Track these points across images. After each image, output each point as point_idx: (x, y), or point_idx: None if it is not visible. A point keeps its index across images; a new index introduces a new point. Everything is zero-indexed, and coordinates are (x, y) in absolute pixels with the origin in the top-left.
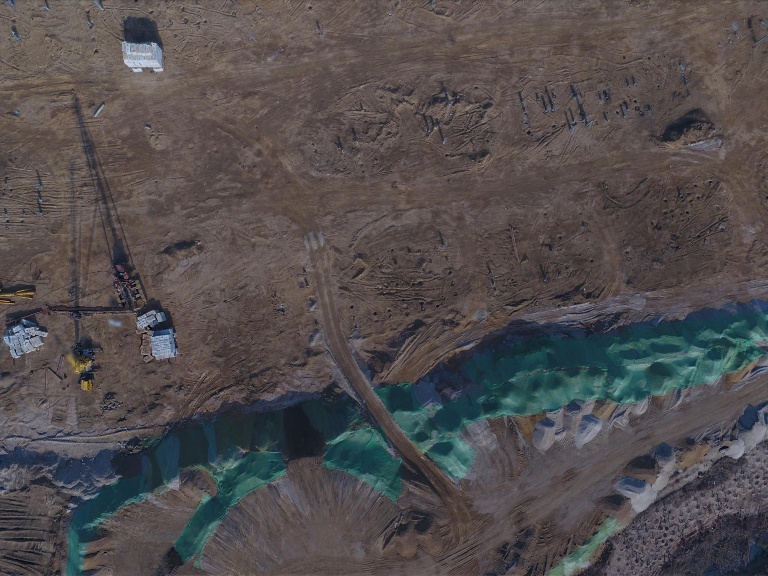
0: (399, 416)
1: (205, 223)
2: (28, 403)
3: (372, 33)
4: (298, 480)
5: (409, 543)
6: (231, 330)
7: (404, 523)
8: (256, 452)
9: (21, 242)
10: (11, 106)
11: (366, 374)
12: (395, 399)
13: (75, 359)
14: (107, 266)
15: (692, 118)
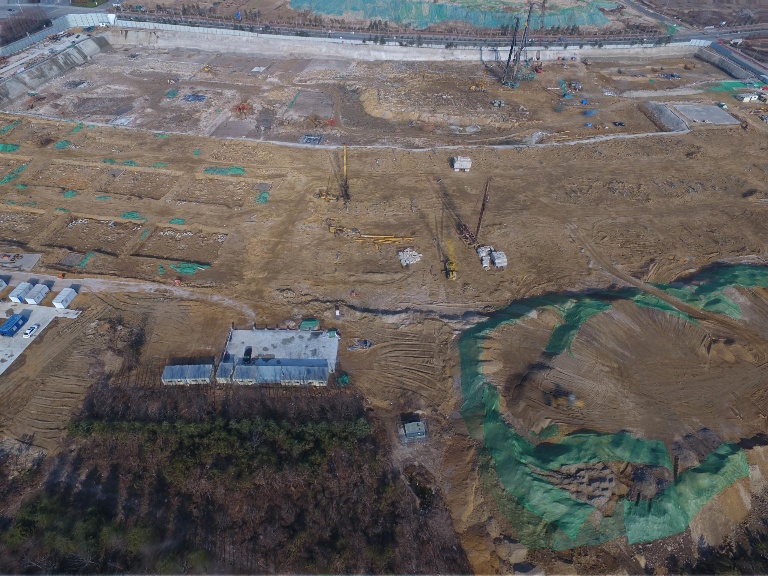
0: (671, 291)
1: (505, 218)
2: (413, 286)
3: (568, 164)
4: (623, 311)
5: (727, 349)
6: (536, 258)
7: (714, 339)
8: (584, 301)
9: (402, 221)
10: (394, 179)
11: (634, 277)
12: None
13: (440, 268)
14: (453, 231)
15: (753, 191)
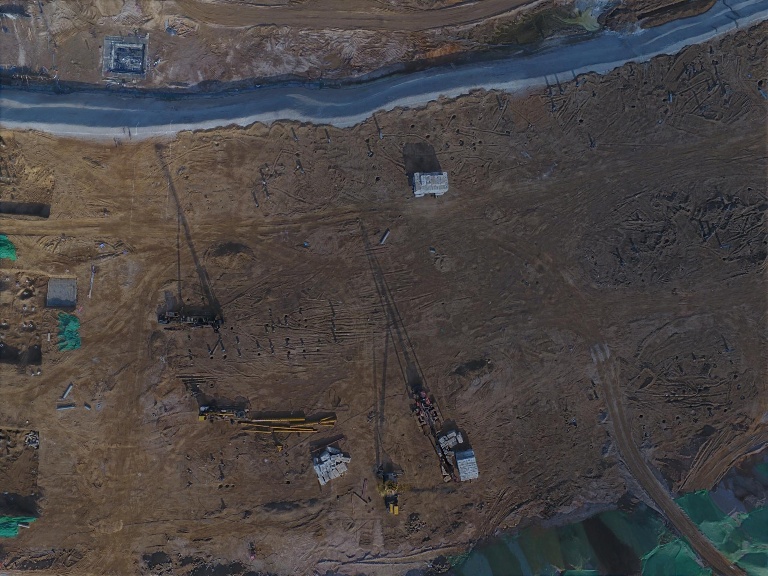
0: (706, 527)
1: (493, 341)
2: (336, 527)
3: (643, 142)
4: None
5: None
6: (526, 446)
7: None
8: (572, 571)
9: (318, 371)
10: (300, 238)
11: (663, 484)
12: (697, 509)
13: (378, 482)
14: (402, 390)
15: None
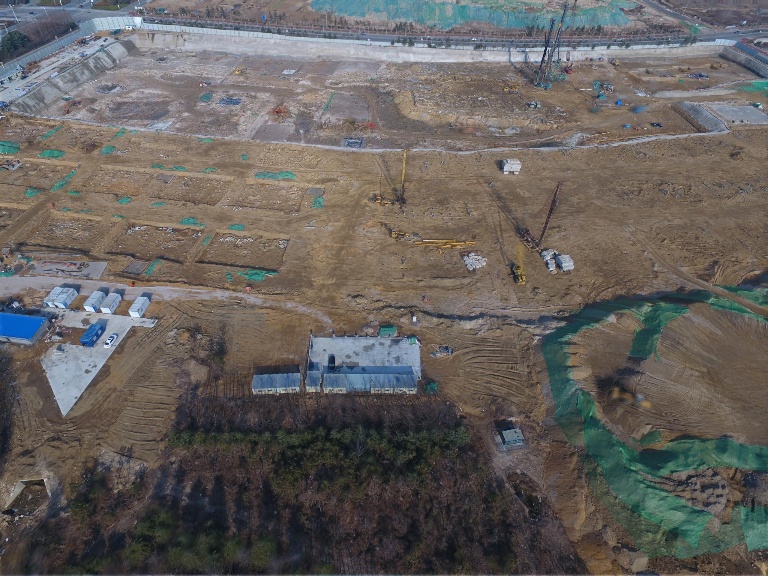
0: (742, 293)
1: (562, 221)
2: (483, 291)
3: (614, 166)
4: (701, 314)
5: None
6: (600, 261)
7: None
8: None
9: (461, 225)
10: (445, 182)
11: None
12: (731, 289)
13: (507, 272)
14: (513, 235)
15: None
